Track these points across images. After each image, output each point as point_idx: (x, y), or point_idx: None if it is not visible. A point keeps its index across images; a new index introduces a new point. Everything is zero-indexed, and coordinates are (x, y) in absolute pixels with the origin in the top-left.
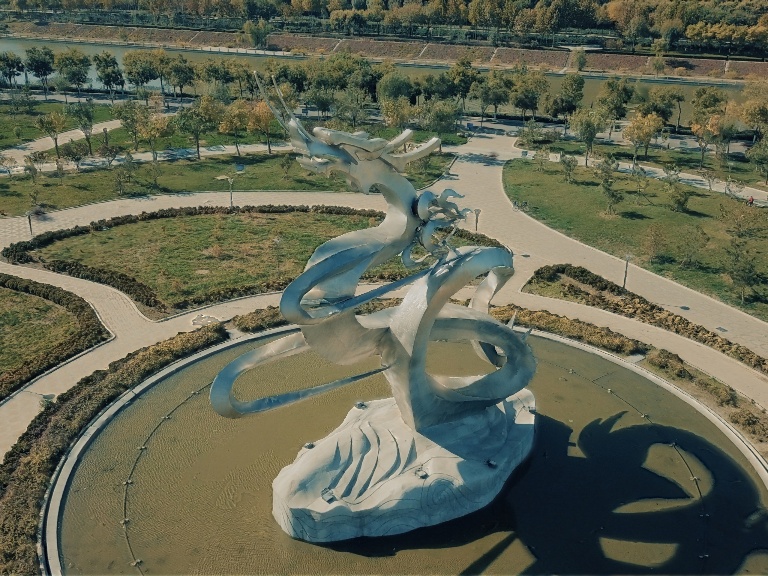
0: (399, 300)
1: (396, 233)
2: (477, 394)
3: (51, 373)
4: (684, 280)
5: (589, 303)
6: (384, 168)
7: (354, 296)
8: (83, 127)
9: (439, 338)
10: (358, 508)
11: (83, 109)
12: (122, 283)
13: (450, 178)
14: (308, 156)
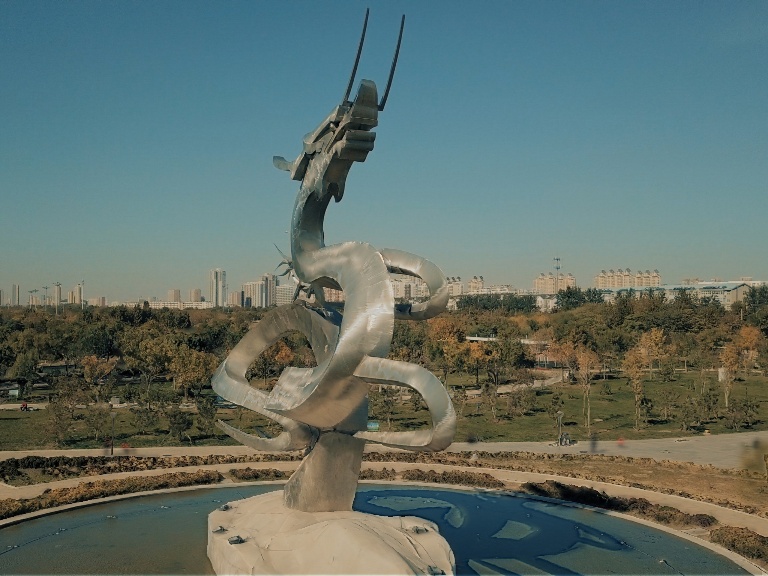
0: None
1: None
2: None
3: None
4: (119, 446)
5: (100, 473)
6: None
7: None
8: None
9: None
10: None
11: None
12: None
13: None
14: (368, 127)
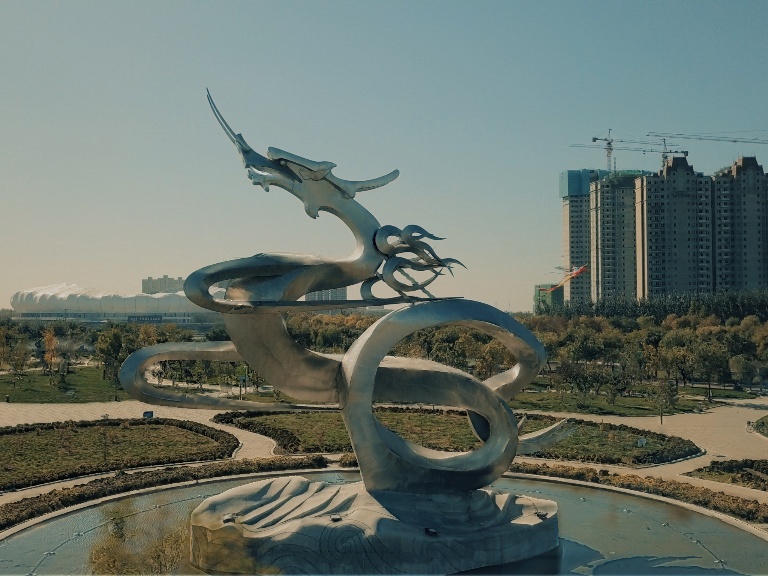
0: None
1: (349, 260)
2: (451, 466)
3: (155, 467)
4: None
5: (759, 487)
6: (335, 193)
7: None
8: None
9: (419, 400)
10: (252, 535)
11: None
12: (279, 435)
13: (699, 413)
14: None
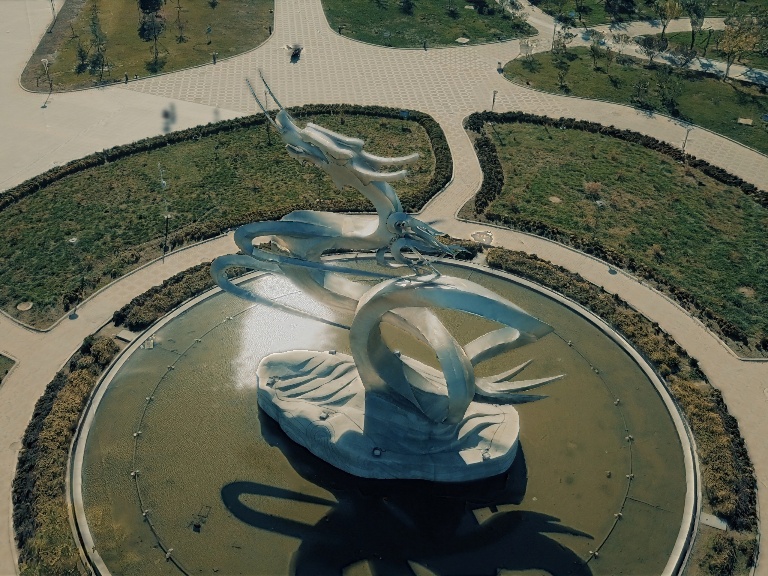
0: (639, 317)
1: (366, 232)
2: (422, 401)
3: None
4: None
5: None
6: None
7: (305, 259)
8: (693, 22)
9: None
10: (277, 402)
11: (695, 4)
12: (488, 178)
13: None
14: None
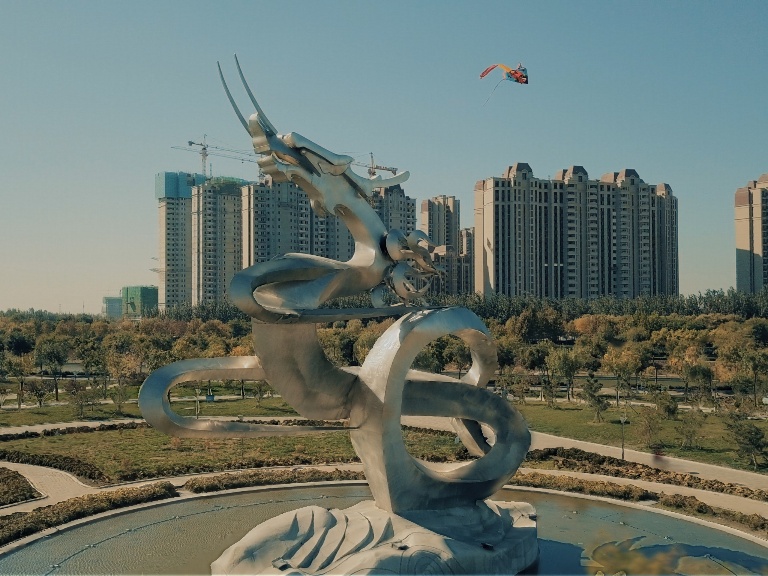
0: None
1: (363, 265)
2: (464, 477)
3: None
4: (688, 457)
5: (587, 471)
6: (349, 191)
7: None
8: (52, 371)
9: (417, 412)
10: None
11: (55, 352)
12: (65, 463)
13: None
14: (268, 153)
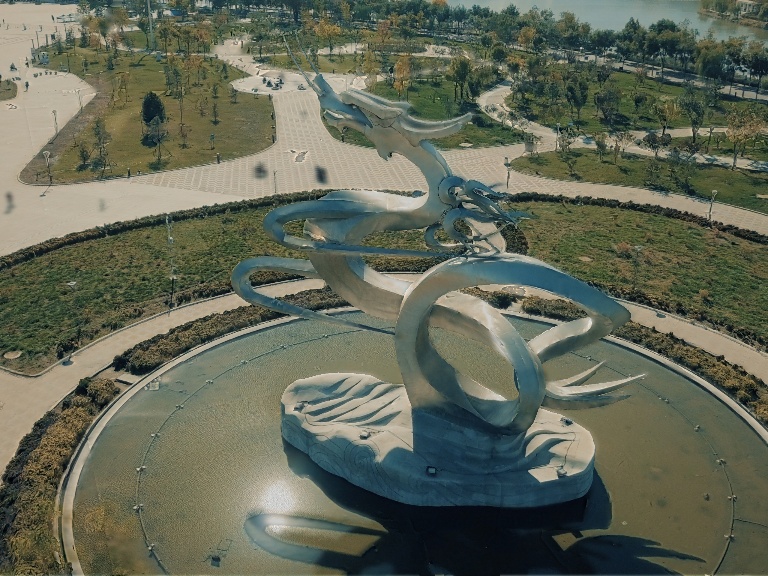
0: (701, 352)
1: (414, 206)
2: (482, 410)
3: None
4: None
5: None
6: (404, 139)
7: (343, 244)
8: (692, 121)
9: (477, 338)
10: (307, 427)
11: (694, 103)
12: (512, 242)
13: None
14: None
